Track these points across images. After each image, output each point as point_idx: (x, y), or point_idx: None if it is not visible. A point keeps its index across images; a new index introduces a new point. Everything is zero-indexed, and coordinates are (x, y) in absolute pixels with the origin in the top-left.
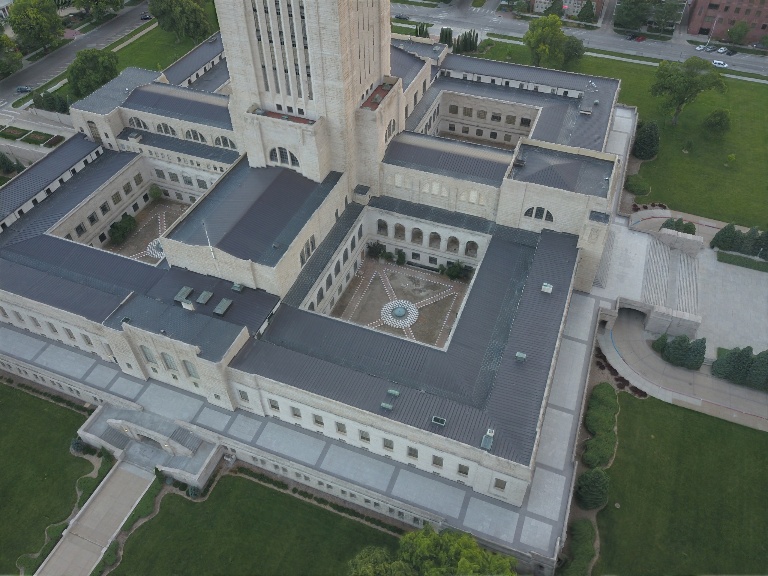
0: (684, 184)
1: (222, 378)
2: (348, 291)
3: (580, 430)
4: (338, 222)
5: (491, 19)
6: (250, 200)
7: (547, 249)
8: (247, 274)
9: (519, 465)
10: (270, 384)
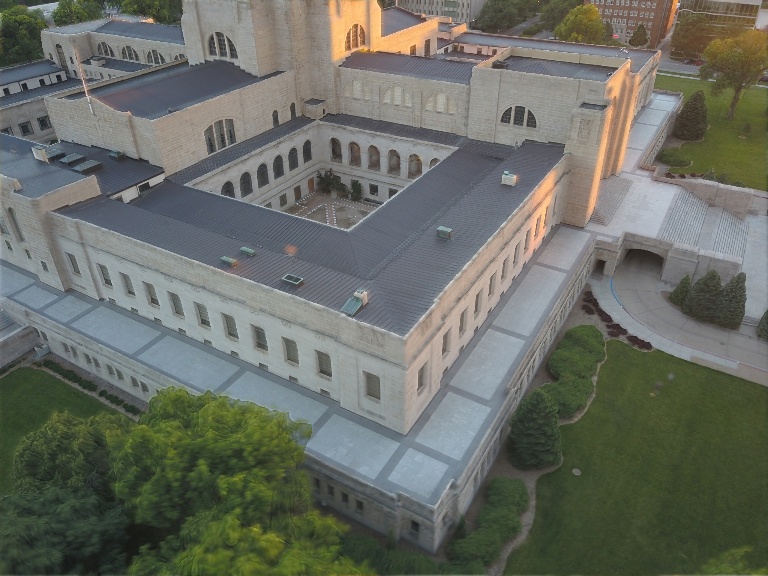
0: (737, 162)
1: (41, 226)
2: None
3: (539, 374)
4: (277, 128)
5: None
6: None
7: (524, 155)
8: (127, 134)
9: (388, 333)
10: (92, 232)
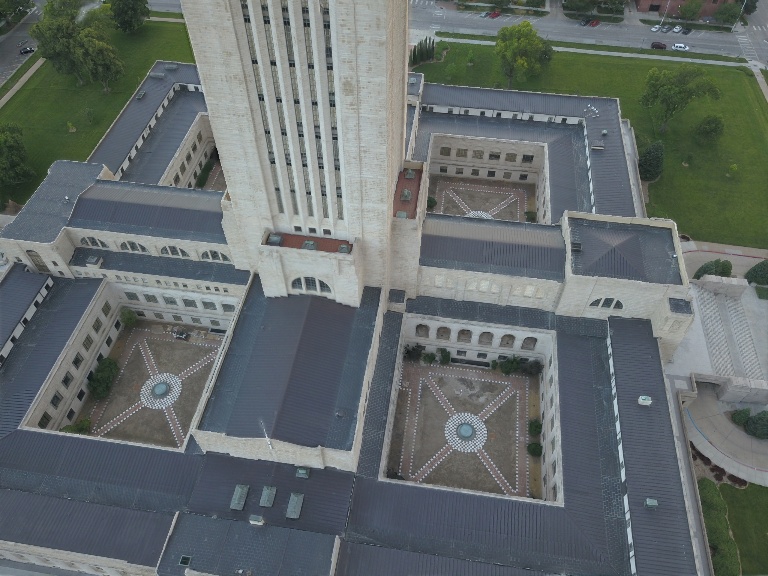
0: (697, 206)
1: None
2: (399, 412)
3: None
4: (381, 343)
5: (434, 13)
6: (288, 353)
7: (623, 343)
8: (315, 459)
9: None
10: None
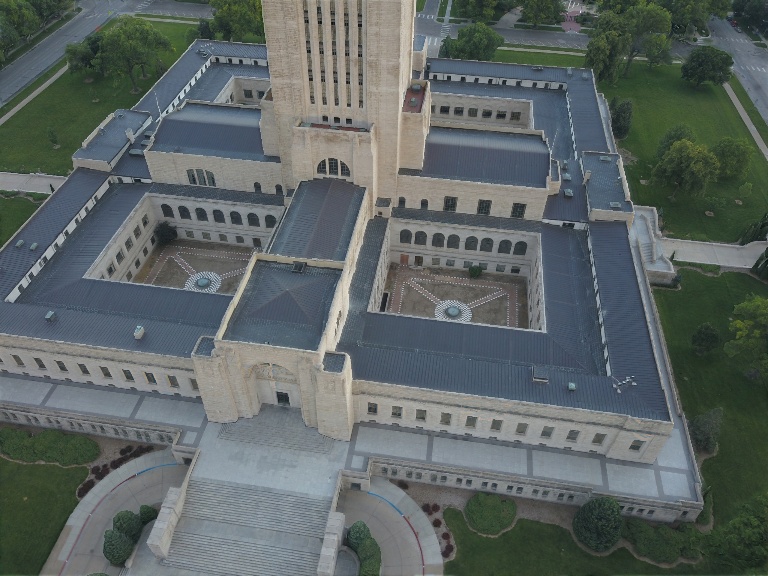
0: None
1: None
2: (232, 248)
3: None
4: (257, 194)
5: None
6: (226, 122)
7: None
8: None
9: None
10: None
